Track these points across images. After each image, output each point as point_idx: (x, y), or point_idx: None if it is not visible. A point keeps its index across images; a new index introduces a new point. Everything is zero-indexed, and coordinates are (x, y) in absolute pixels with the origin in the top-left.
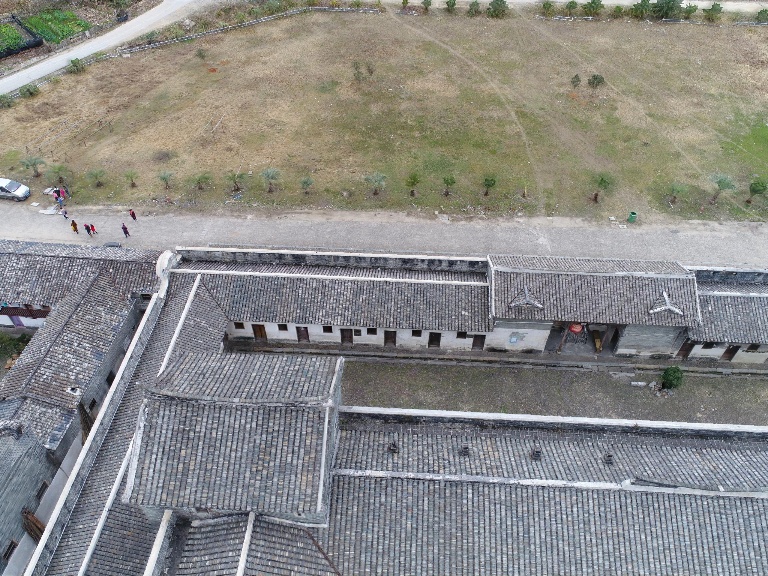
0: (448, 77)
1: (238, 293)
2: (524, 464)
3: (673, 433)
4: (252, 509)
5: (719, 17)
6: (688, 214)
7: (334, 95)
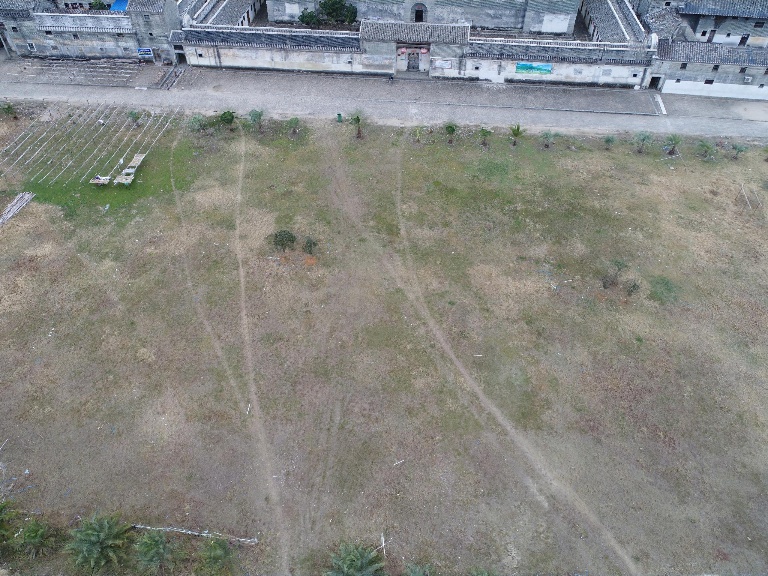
0: (485, 307)
1: None
2: None
3: None
4: None
5: None
6: None
7: (645, 272)
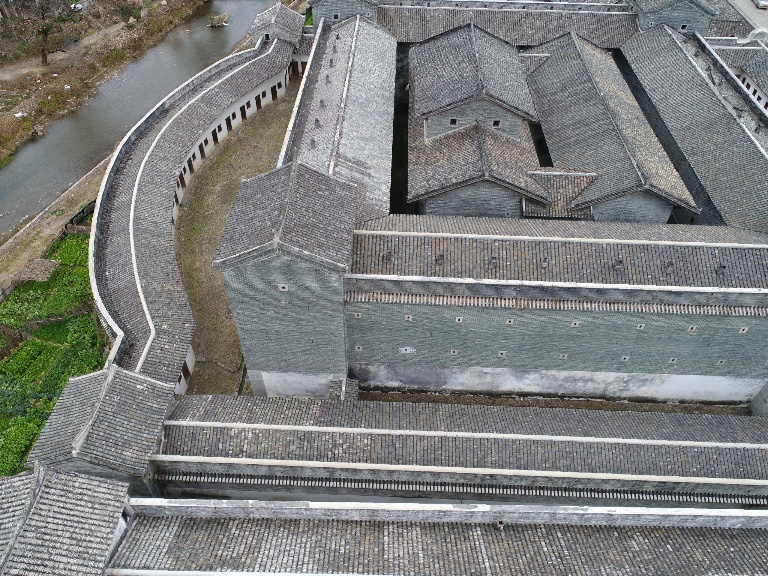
0: None
1: (762, 63)
2: (700, 65)
3: (755, 111)
4: (638, 2)
5: None
6: None
7: None
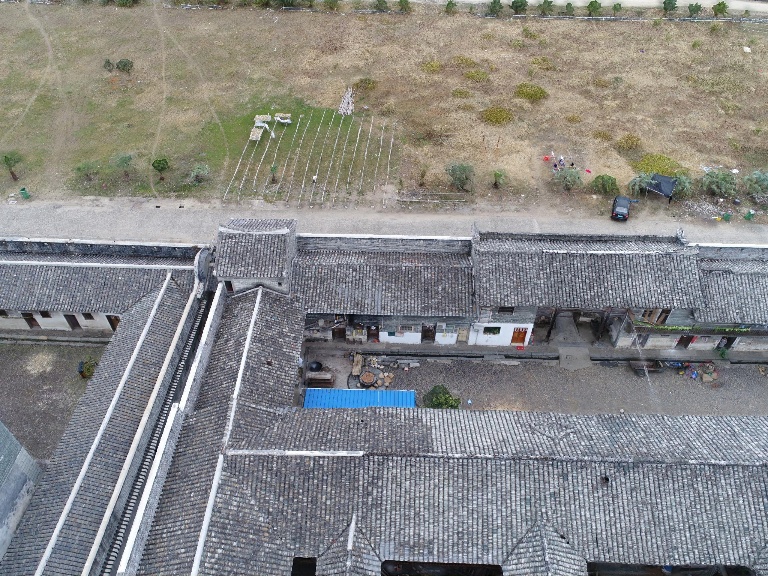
0: (11, 63)
1: None
2: None
3: None
4: None
5: (337, 5)
6: (91, 191)
7: None
